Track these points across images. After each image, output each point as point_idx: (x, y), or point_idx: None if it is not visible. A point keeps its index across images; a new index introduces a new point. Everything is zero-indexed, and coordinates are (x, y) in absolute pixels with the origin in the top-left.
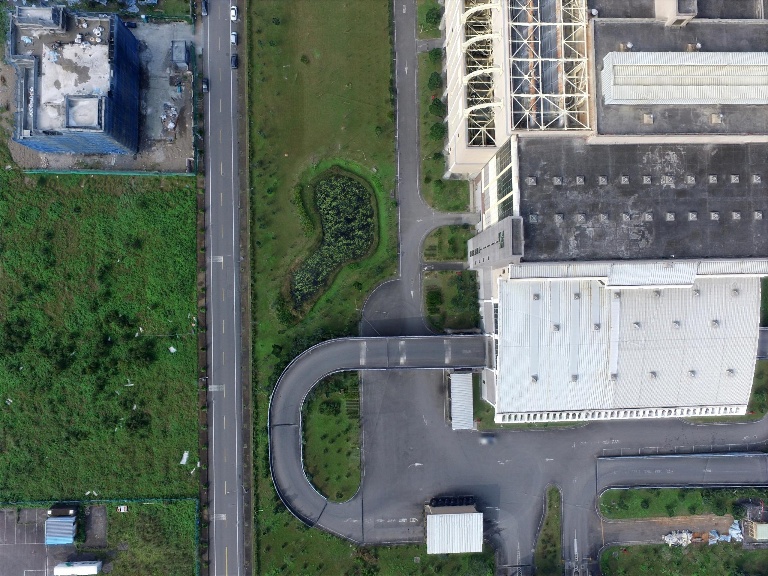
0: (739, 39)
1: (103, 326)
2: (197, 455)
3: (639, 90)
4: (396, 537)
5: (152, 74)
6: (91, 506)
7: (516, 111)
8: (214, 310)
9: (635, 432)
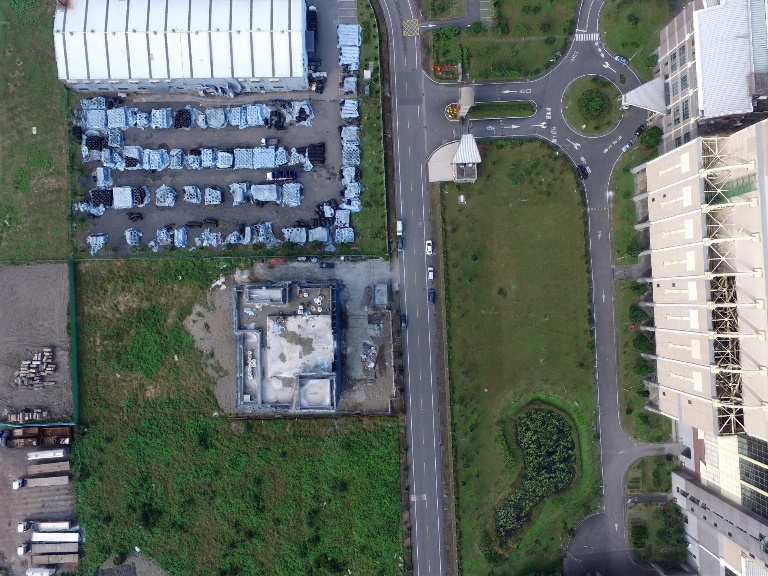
0: None
1: (313, 570)
2: None
3: None
4: None
5: (350, 313)
6: None
7: None
8: (419, 549)
9: None
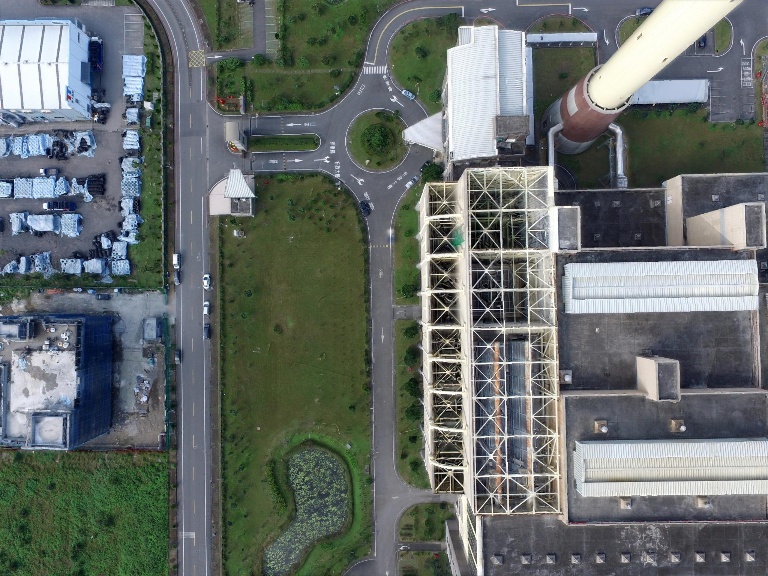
0: (731, 410)
1: None
2: None
3: (613, 487)
4: None
5: (125, 346)
6: None
7: (480, 494)
8: None
9: None
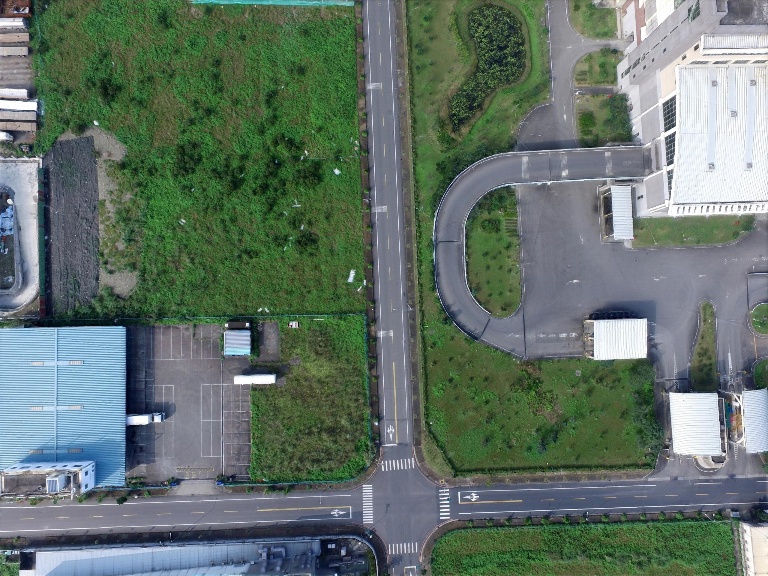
0: None
1: (270, 149)
2: (363, 273)
3: None
4: (557, 351)
5: None
6: (263, 322)
7: None
8: (375, 134)
9: None
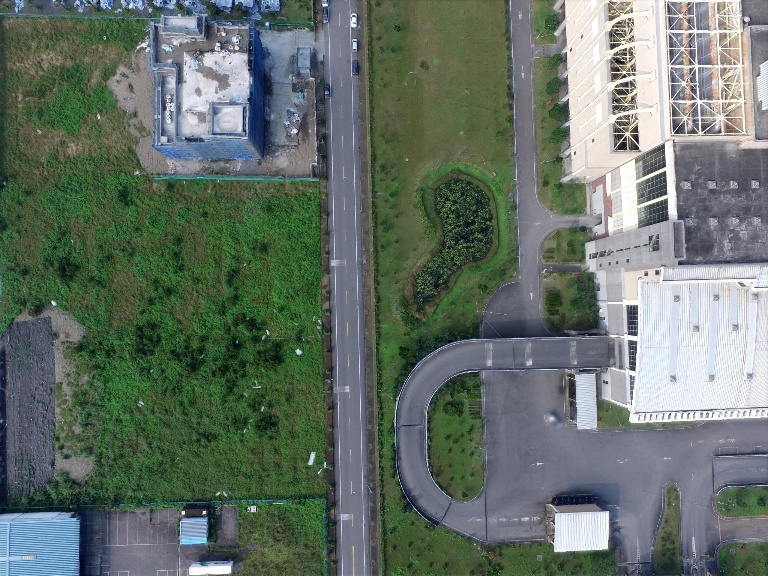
0: None
1: (231, 329)
2: (324, 456)
3: None
4: (519, 535)
5: (275, 81)
6: (221, 507)
7: (675, 117)
8: (338, 313)
9: (750, 431)
